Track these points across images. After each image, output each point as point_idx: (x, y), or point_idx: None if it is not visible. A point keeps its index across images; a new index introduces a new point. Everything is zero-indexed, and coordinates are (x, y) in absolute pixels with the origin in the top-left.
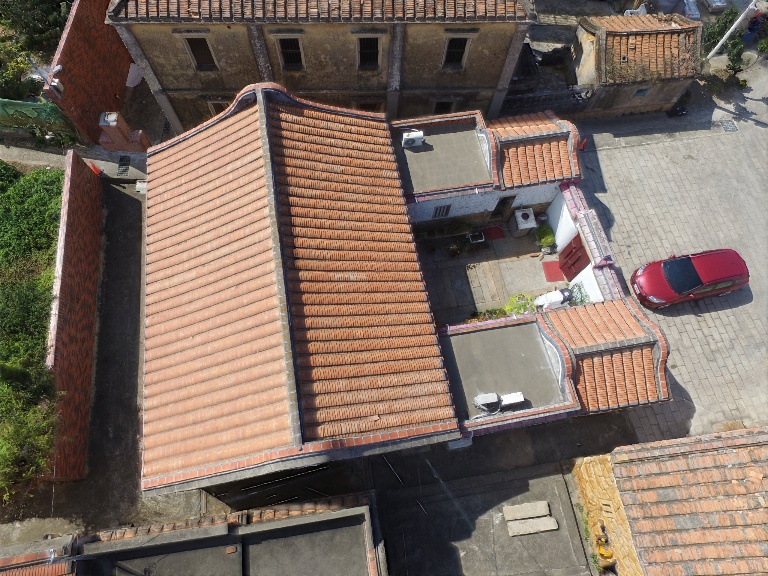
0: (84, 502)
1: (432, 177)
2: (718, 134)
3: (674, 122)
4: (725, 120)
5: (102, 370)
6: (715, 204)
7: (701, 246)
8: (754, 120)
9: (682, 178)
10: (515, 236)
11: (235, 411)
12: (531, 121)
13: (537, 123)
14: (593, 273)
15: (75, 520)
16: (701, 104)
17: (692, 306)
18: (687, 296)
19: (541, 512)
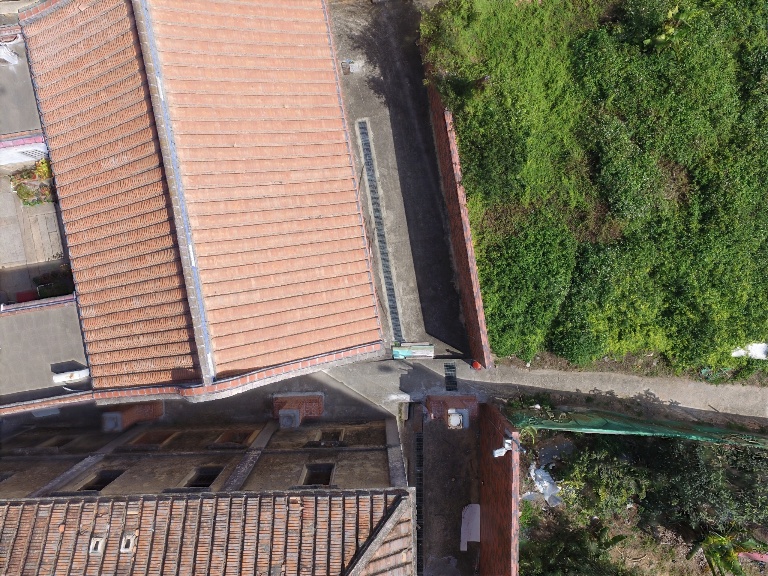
0: (418, 22)
1: (54, 326)
2: None
3: None
4: None
5: (428, 141)
6: None
7: None
8: None
9: None
10: (2, 292)
11: (219, 17)
12: None
13: None
14: None
15: (423, 7)
16: None
17: None
18: None
19: (5, 4)
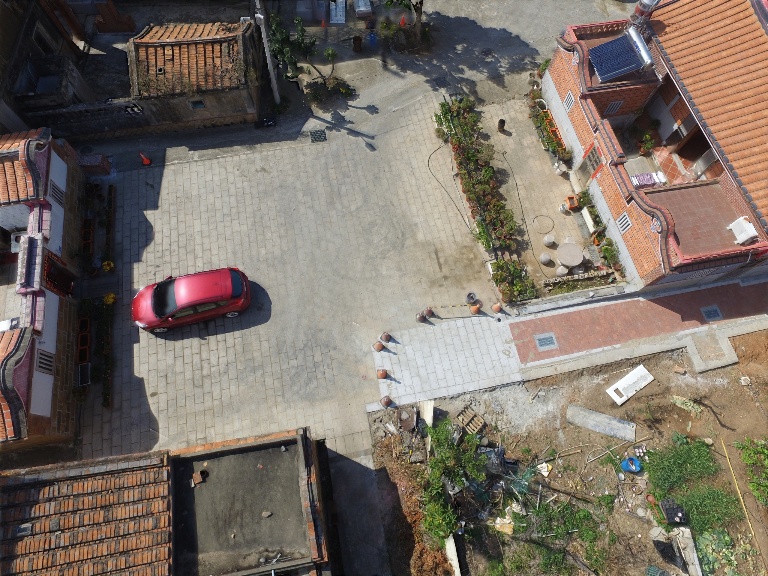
0: None
1: None
2: (302, 145)
3: (259, 133)
4: (316, 130)
5: None
6: (270, 219)
7: (236, 264)
8: (348, 129)
9: (245, 192)
10: None
11: None
12: (11, 139)
13: (14, 142)
14: (21, 301)
15: None
16: (297, 114)
17: (200, 328)
18: (167, 320)
19: None
